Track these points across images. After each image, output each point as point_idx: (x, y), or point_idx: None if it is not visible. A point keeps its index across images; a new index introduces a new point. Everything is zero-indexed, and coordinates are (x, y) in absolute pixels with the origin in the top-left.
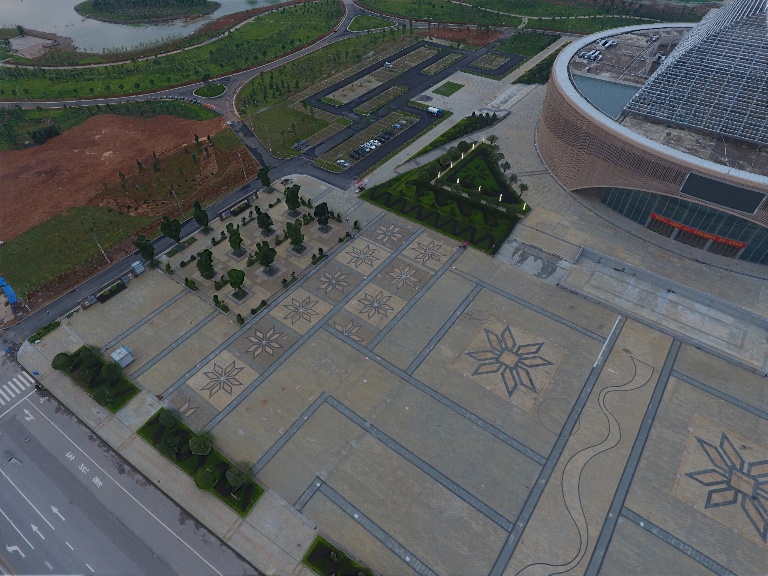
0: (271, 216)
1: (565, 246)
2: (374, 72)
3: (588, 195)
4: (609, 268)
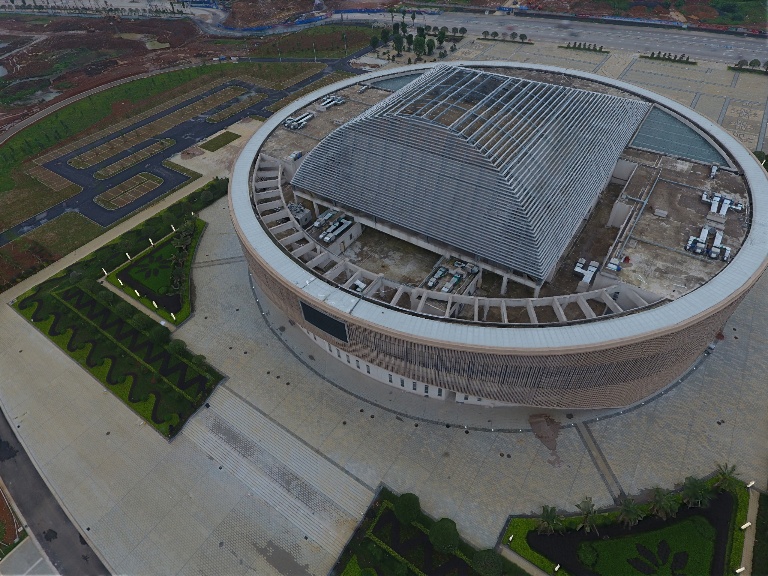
0: None
1: None
2: None
3: None
4: None
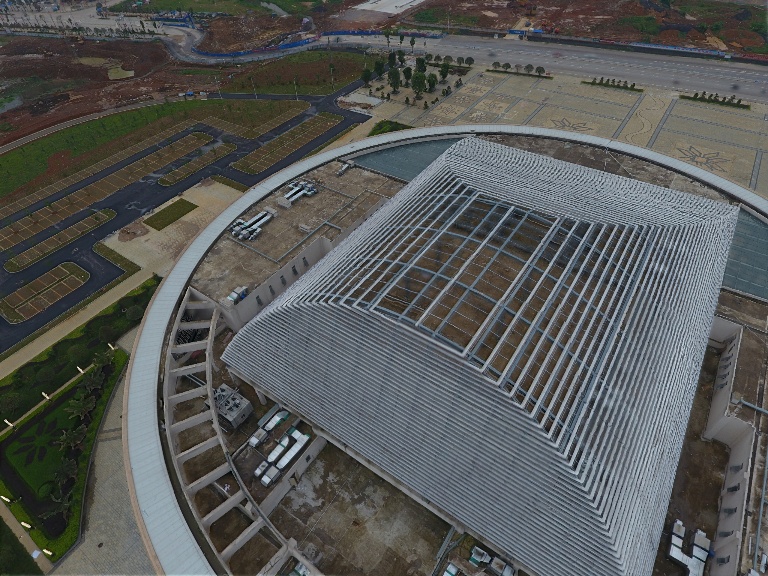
0: None
1: None
2: None
3: None
4: None
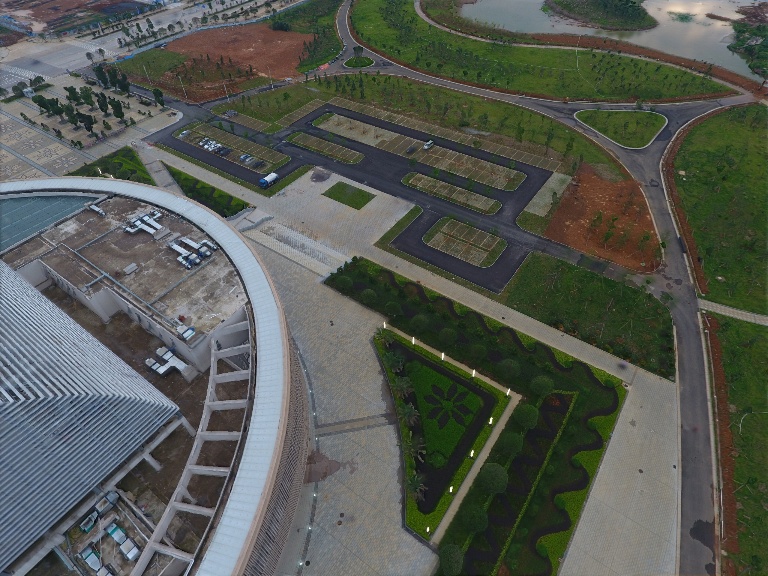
0: (127, 114)
1: None
2: (409, 138)
3: None
4: None
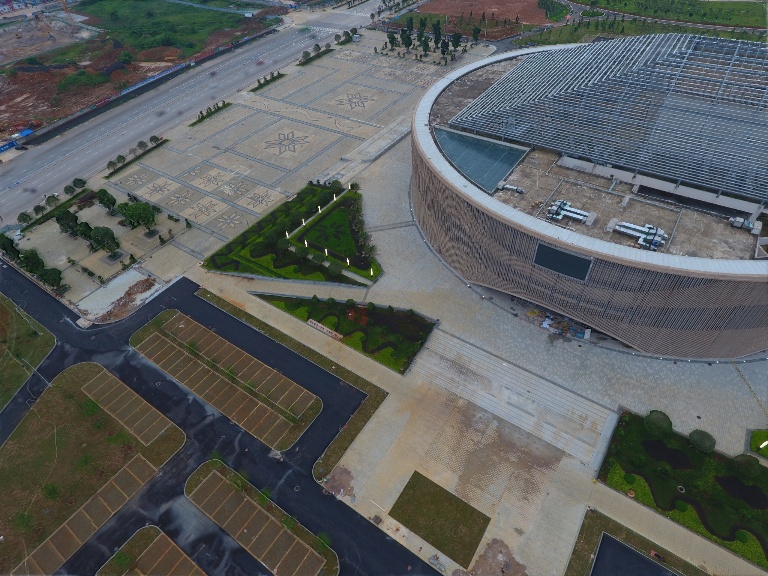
0: (451, 47)
1: None
2: None
3: None
4: None
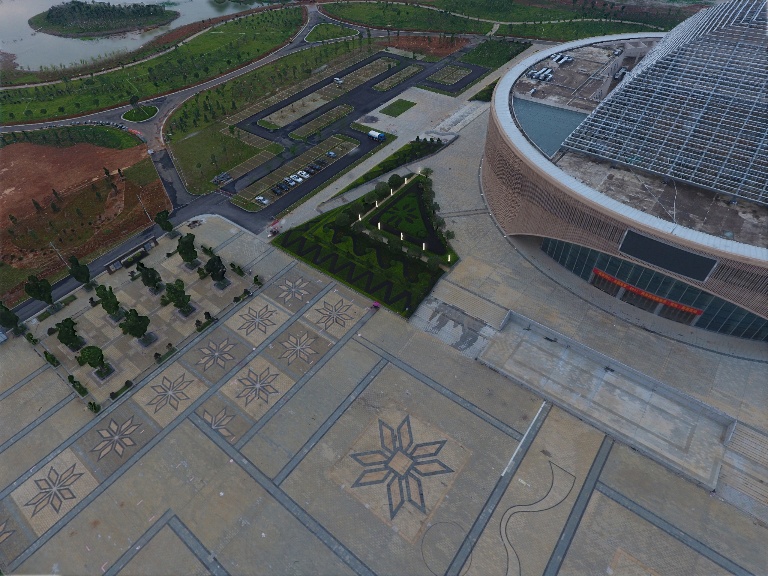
0: (166, 268)
1: (491, 308)
2: (321, 89)
3: (528, 241)
4: (540, 337)
